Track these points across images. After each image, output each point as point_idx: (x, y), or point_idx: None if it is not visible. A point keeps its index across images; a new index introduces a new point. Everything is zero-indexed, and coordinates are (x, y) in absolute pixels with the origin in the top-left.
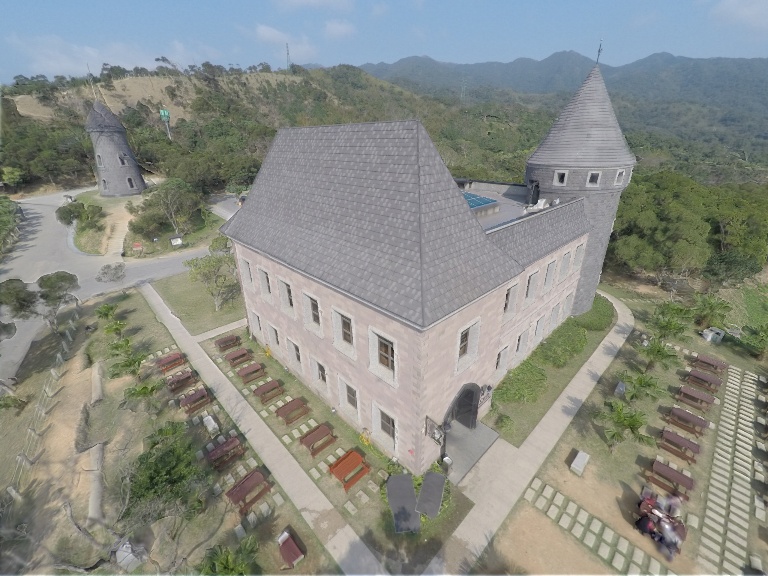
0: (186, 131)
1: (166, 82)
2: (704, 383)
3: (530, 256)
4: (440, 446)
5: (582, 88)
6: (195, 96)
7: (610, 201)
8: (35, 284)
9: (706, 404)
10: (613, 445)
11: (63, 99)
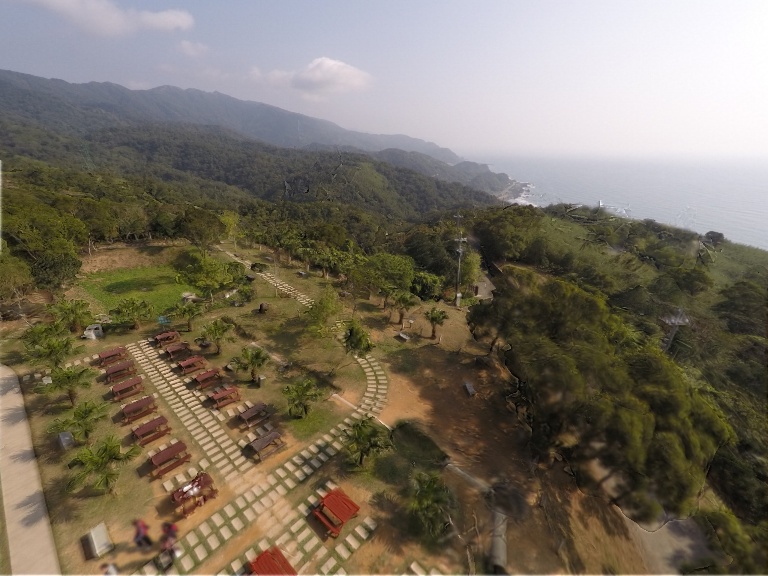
0: None
1: None
2: (123, 372)
3: None
4: None
5: None
6: None
7: None
8: None
9: (139, 385)
10: (112, 488)
11: None
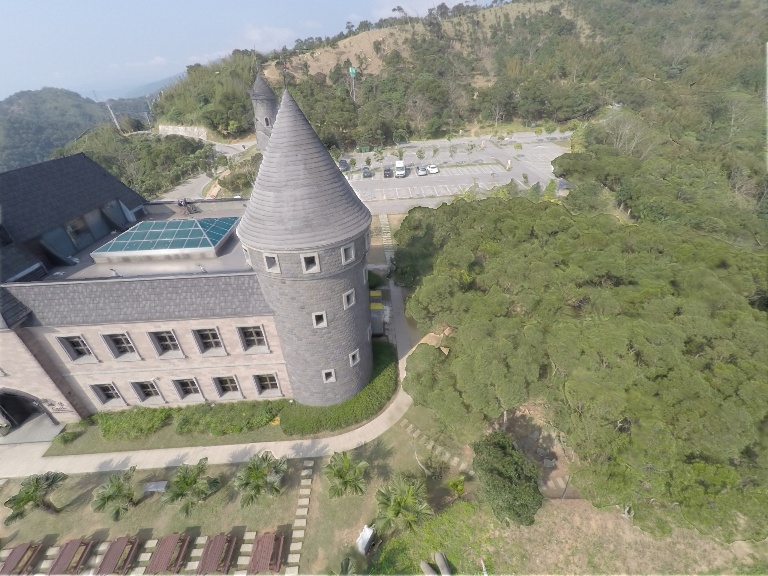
0: (364, 87)
1: (378, 35)
2: None
3: (90, 317)
4: (4, 417)
5: None
6: (402, 46)
7: (283, 289)
8: None
9: None
10: None
11: (299, 60)
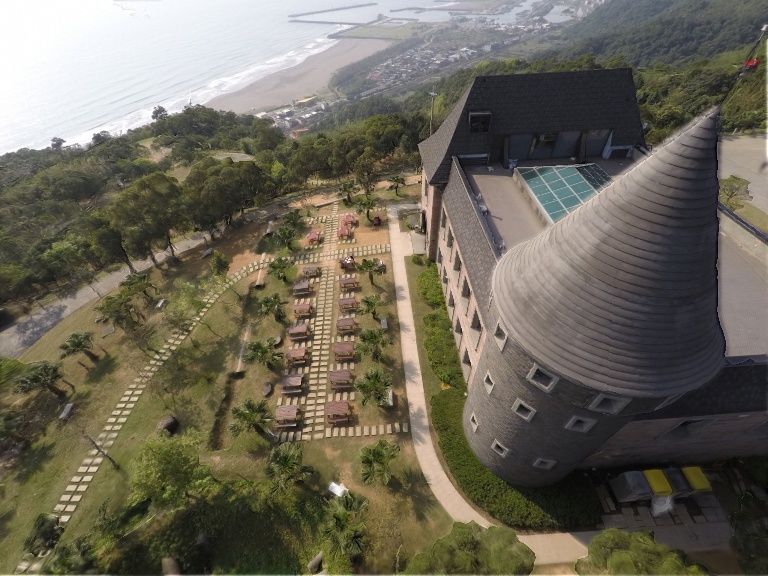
0: None
1: None
2: None
3: None
4: None
5: None
6: None
7: None
8: (652, 130)
9: None
10: None
11: None
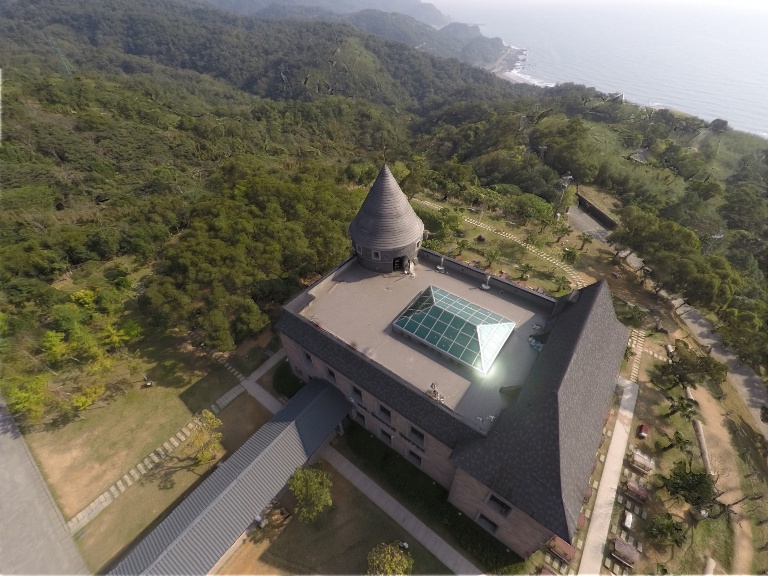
0: None
1: None
2: None
3: None
4: None
5: (389, 184)
6: None
7: None
8: None
9: None
10: None
11: None
